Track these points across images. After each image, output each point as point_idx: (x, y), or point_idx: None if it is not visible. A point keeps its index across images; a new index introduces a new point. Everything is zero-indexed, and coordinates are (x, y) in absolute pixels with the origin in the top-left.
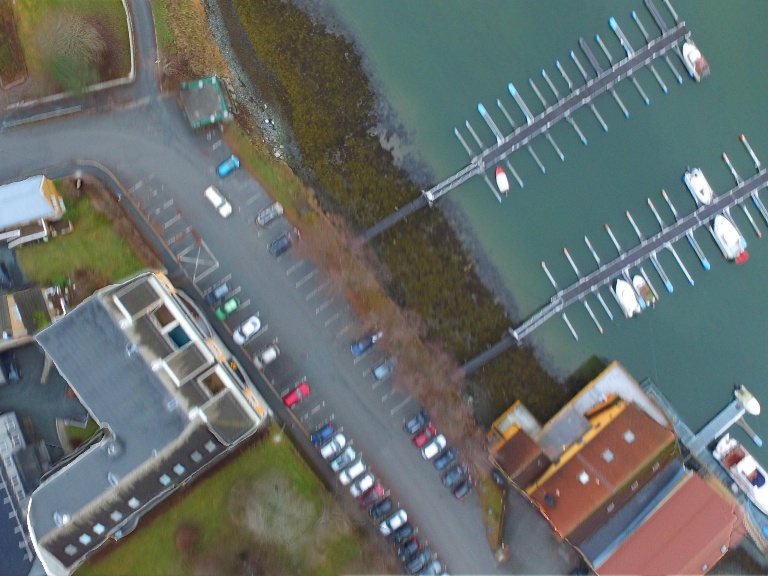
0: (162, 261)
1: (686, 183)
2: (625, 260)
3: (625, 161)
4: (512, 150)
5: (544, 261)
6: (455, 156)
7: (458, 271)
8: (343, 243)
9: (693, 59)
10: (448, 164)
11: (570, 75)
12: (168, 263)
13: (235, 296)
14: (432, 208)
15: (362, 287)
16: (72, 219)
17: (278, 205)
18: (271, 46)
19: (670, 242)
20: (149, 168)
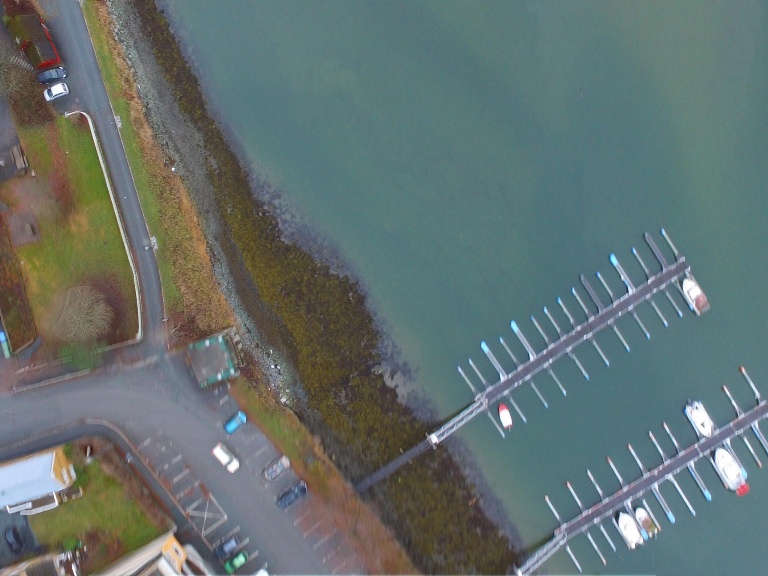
0: (171, 516)
1: (687, 415)
2: (627, 492)
3: (626, 395)
4: (515, 386)
5: (547, 495)
6: (459, 392)
7: (463, 506)
8: (349, 489)
9: (693, 296)
10: (452, 400)
11: (571, 312)
12: (177, 518)
13: (243, 549)
14: (436, 449)
15: (368, 533)
16: (82, 484)
17: (285, 459)
18: (276, 289)
19: (672, 474)
20: (157, 425)
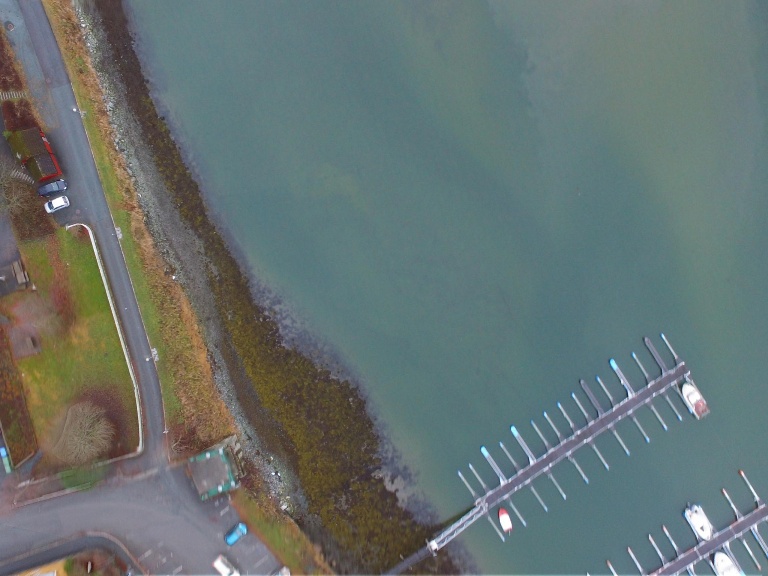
0: None
1: (686, 518)
2: None
3: (626, 498)
4: (515, 490)
5: None
6: (459, 496)
7: None
8: None
9: (692, 401)
10: (452, 504)
11: (571, 416)
12: None
13: None
14: None
15: None
16: None
17: (285, 569)
18: (276, 395)
19: None
20: (158, 536)
